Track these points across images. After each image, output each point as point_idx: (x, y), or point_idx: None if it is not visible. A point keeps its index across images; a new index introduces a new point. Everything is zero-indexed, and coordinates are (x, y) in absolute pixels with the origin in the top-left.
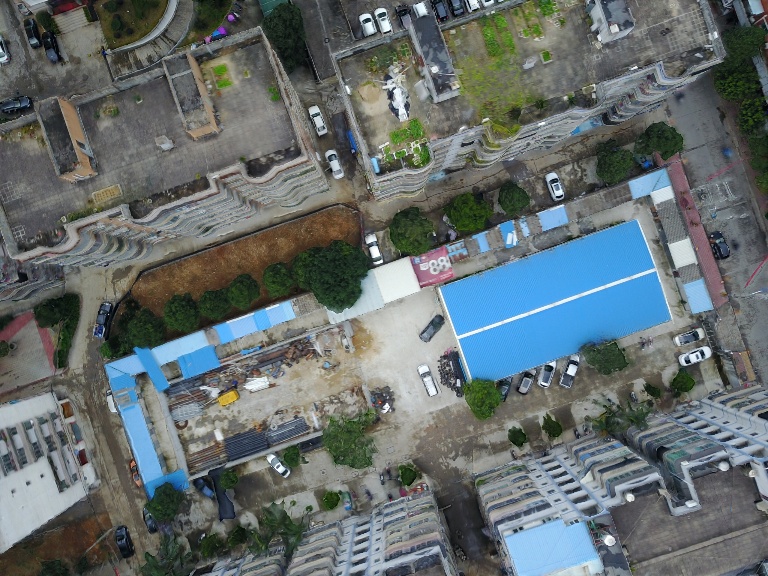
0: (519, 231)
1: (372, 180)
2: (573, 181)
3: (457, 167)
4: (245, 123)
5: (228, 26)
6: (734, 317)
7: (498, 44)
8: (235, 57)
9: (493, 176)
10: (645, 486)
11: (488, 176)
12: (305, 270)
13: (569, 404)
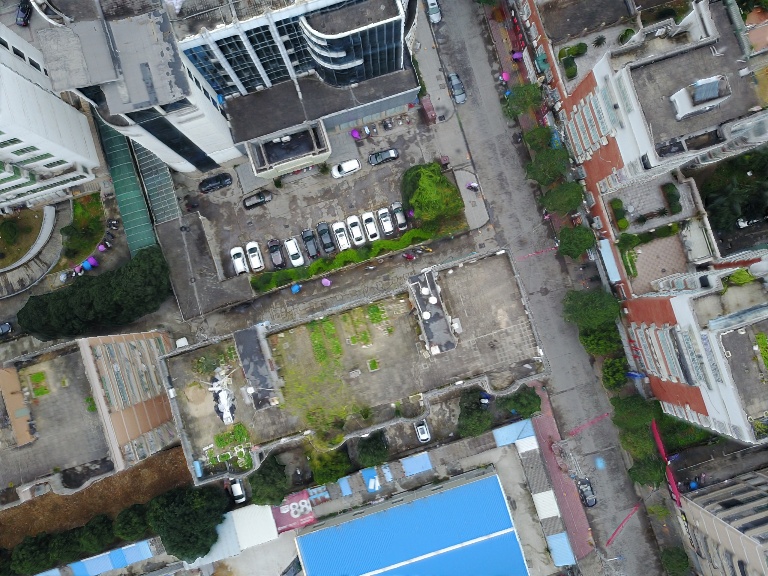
0: (382, 476)
1: None
2: (441, 421)
3: None
4: (61, 432)
5: (100, 254)
6: (601, 565)
7: (325, 351)
8: (54, 364)
9: None
10: None
11: None
12: (155, 523)
13: None
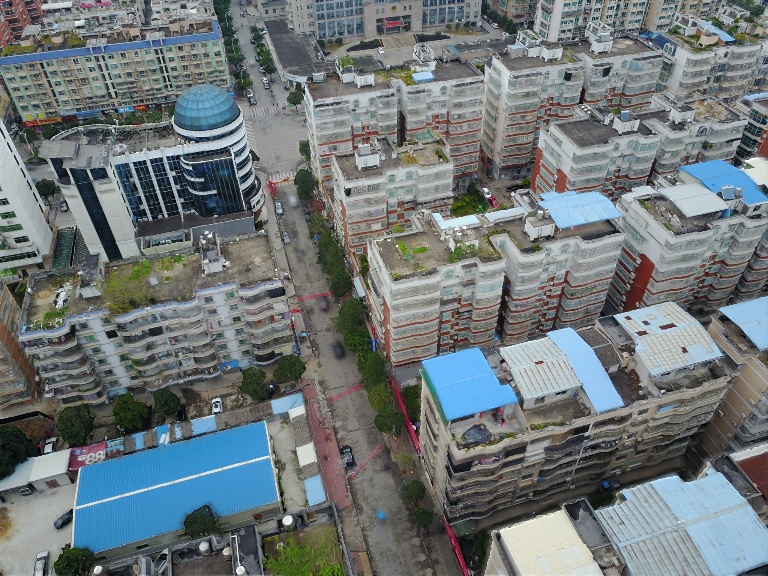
0: (173, 433)
1: (19, 339)
2: (235, 406)
3: (138, 386)
4: None
5: None
6: (357, 518)
7: None
8: None
9: None
10: (128, 572)
11: None
12: None
13: None
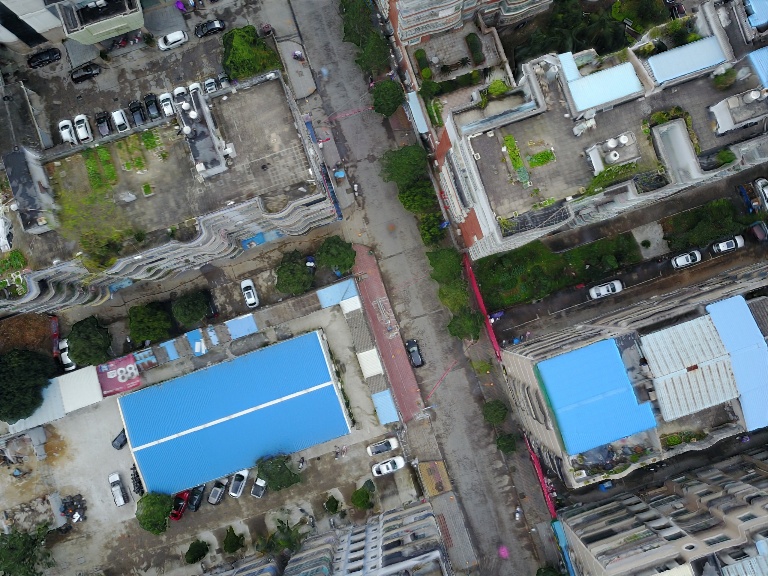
0: (208, 339)
1: None
2: (270, 287)
3: None
4: None
5: None
6: (430, 426)
7: (100, 177)
8: None
9: (191, 282)
10: None
11: (186, 282)
12: None
13: (263, 514)
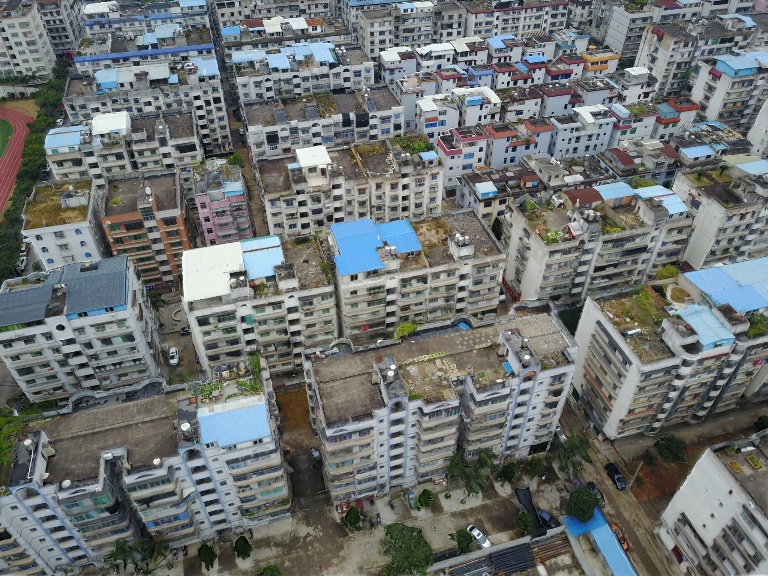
0: None
1: None
2: None
3: None
4: None
5: None
6: None
7: None
8: None
9: None
10: None
11: None
12: None
13: None
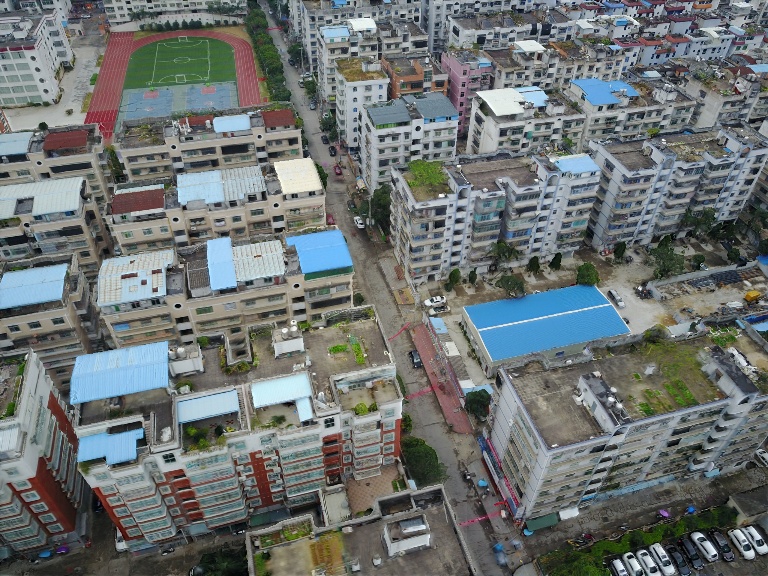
0: None
1: None
2: None
3: None
4: None
5: None
6: None
7: (678, 386)
8: None
9: None
10: None
11: None
12: None
13: None
